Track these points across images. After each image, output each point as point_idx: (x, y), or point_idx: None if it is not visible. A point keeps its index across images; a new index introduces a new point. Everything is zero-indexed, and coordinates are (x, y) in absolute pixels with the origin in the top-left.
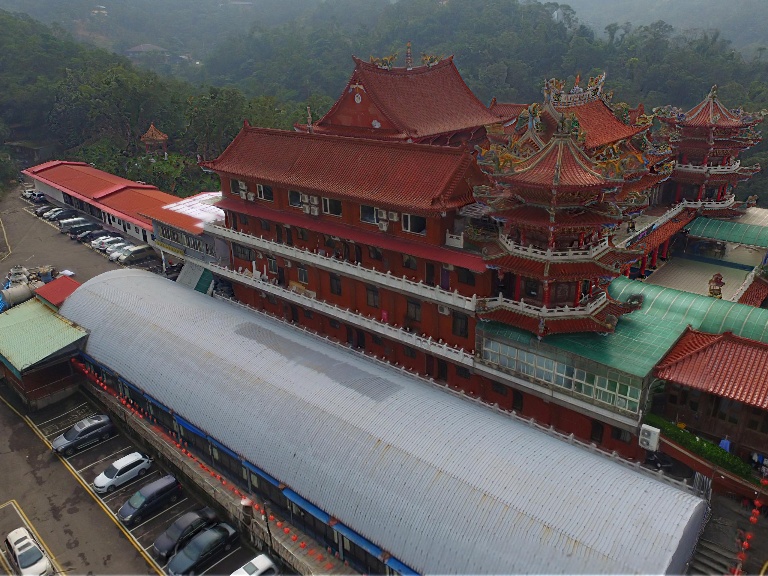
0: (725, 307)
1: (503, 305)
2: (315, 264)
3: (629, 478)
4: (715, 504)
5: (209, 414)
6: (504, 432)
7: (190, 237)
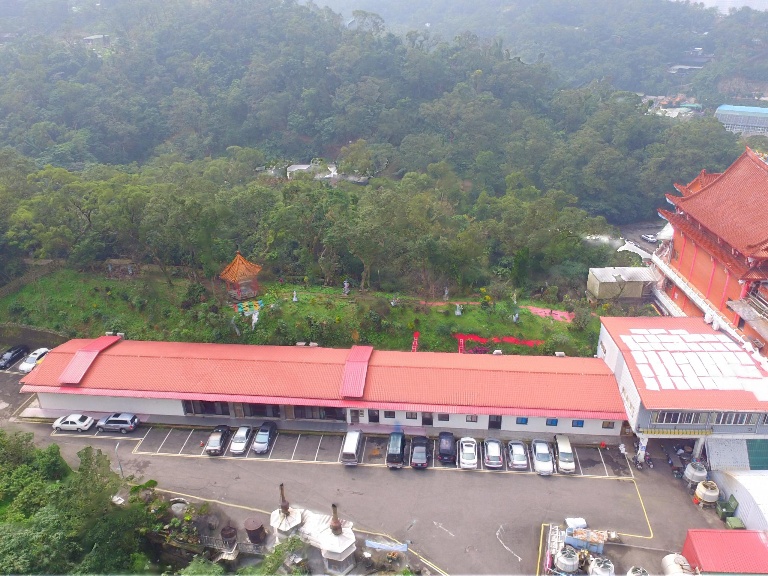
0: None
1: None
2: None
3: None
4: None
5: None
6: None
7: (732, 413)
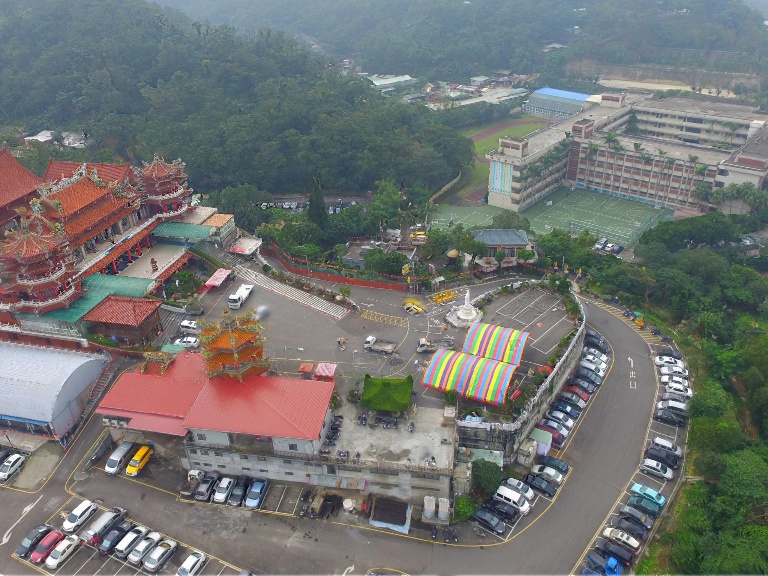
0: (126, 282)
1: (25, 304)
2: None
3: (68, 359)
4: (115, 359)
5: None
6: (24, 356)
7: None
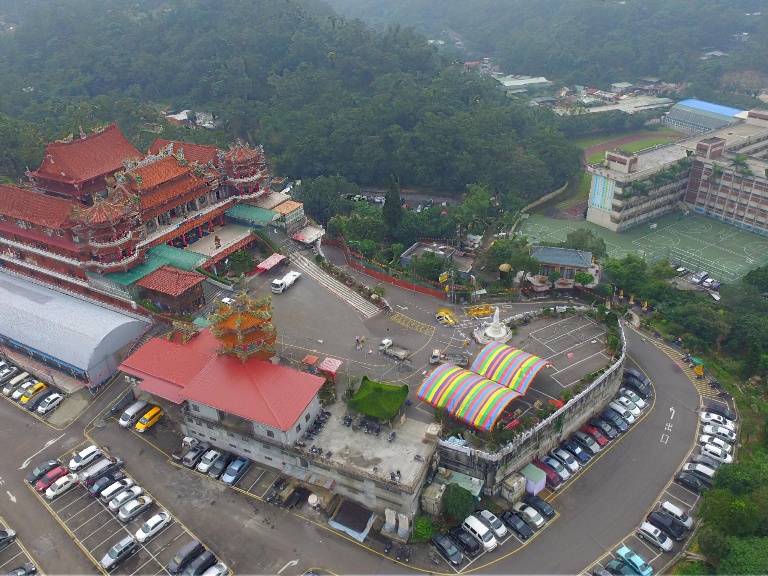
0: (181, 255)
1: (93, 264)
2: (29, 250)
3: (115, 317)
4: (158, 324)
5: None
6: (83, 309)
7: None
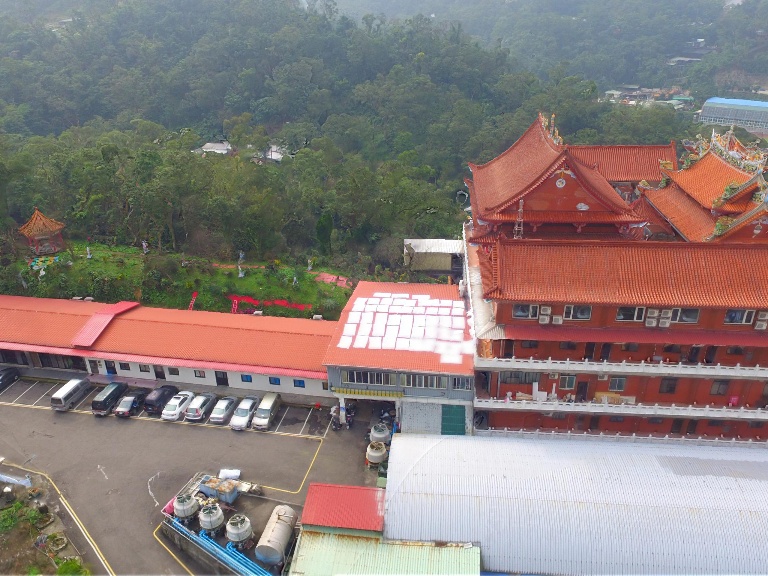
0: None
1: None
2: (674, 374)
3: None
4: None
5: (759, 570)
6: None
7: (420, 375)
